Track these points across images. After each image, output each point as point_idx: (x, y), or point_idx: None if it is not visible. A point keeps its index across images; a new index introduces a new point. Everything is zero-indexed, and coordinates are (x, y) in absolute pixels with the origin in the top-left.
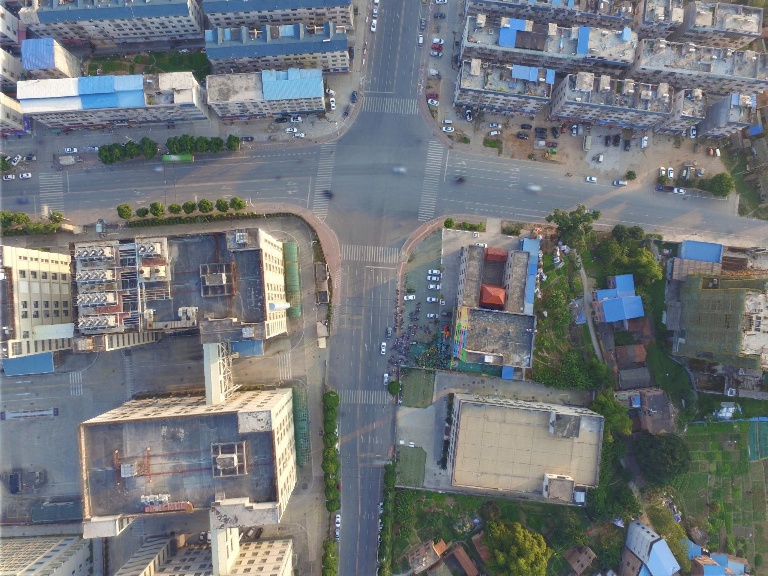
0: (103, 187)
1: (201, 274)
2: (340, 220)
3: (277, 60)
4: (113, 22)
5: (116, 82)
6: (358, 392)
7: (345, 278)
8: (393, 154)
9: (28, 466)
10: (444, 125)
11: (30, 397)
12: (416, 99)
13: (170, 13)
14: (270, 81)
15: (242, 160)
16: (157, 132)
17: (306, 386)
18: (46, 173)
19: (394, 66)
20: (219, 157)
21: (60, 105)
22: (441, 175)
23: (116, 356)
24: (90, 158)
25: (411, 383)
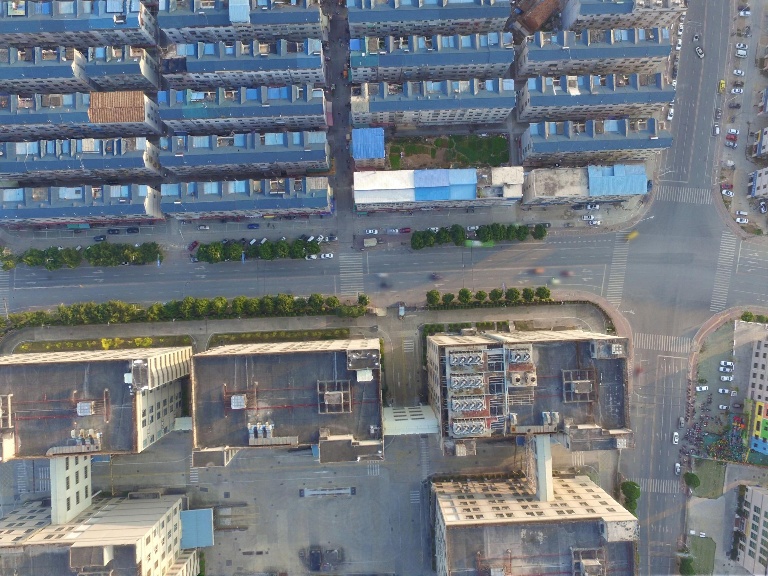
0: (402, 269)
1: (565, 380)
2: (633, 308)
3: (592, 152)
4: (436, 112)
5: (450, 176)
6: (649, 481)
7: (638, 366)
8: (686, 244)
9: (326, 543)
10: (738, 216)
11: (328, 475)
12: (710, 189)
13: (497, 105)
14: (596, 177)
15: (538, 246)
16: (456, 216)
17: (598, 473)
18: (346, 253)
19: (689, 155)
20: (516, 242)
21: (393, 196)
22: (734, 266)
23: (413, 437)
24: (390, 240)
25: (702, 473)
